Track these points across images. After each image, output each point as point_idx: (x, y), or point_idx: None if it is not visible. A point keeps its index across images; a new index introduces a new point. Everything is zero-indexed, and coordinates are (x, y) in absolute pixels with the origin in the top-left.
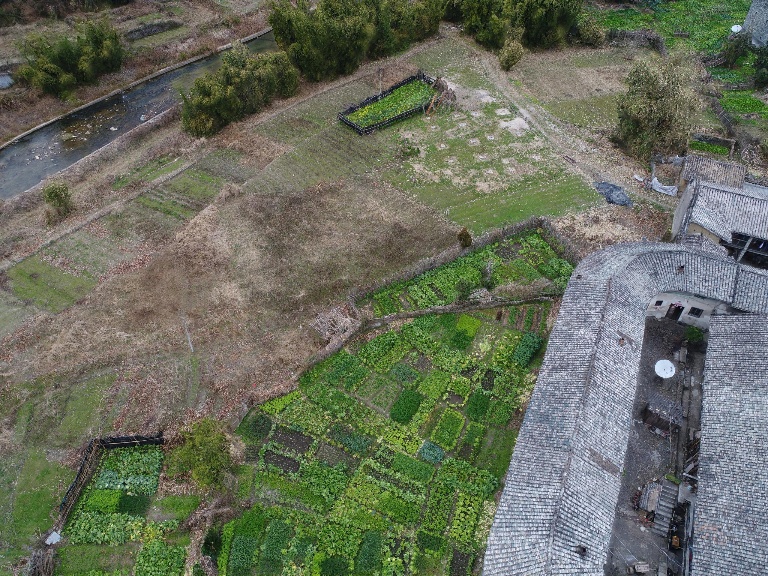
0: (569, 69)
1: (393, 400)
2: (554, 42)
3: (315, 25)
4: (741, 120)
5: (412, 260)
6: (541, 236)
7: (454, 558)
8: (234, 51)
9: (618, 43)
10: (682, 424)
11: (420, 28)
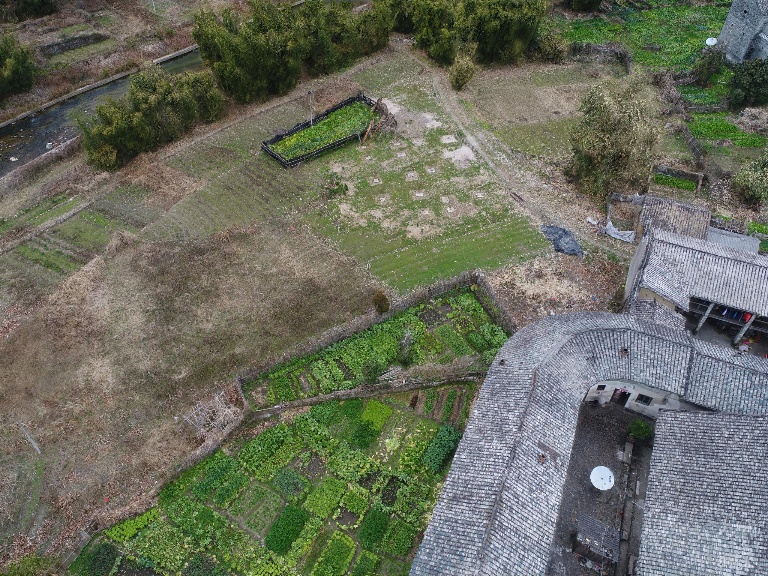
0: (527, 88)
1: (272, 520)
2: (513, 57)
3: (239, 42)
4: (712, 148)
5: (321, 327)
6: (475, 294)
7: None
8: (143, 73)
9: (582, 58)
10: (617, 559)
11: (366, 42)
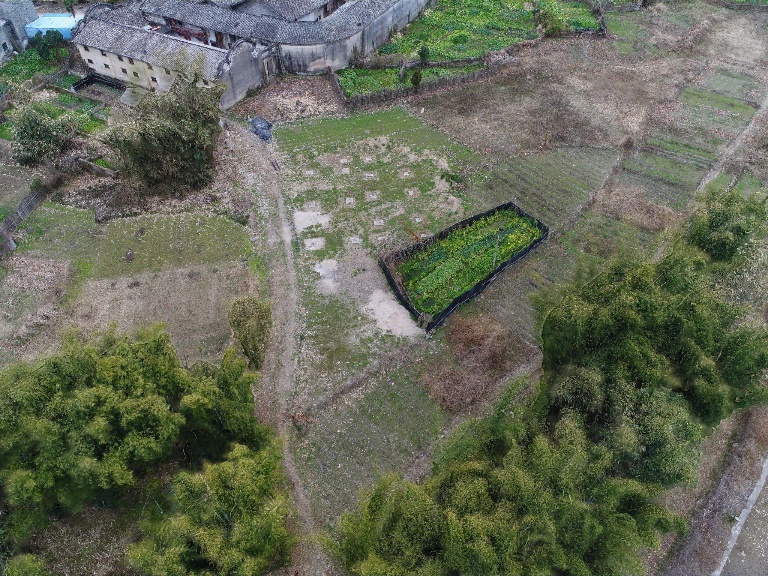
0: None
1: None
2: None
3: None
4: (0, 214)
5: None
6: None
7: None
8: (742, 222)
9: None
10: None
11: None
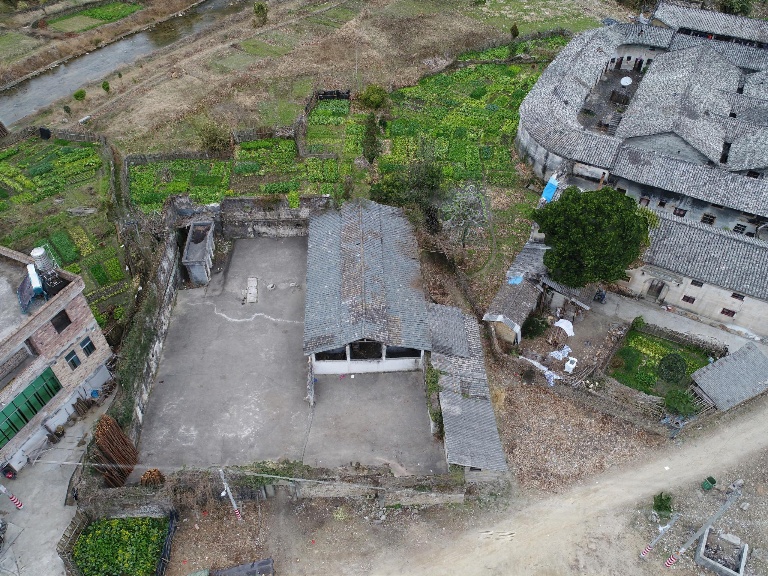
0: None
1: (471, 92)
2: None
3: None
4: None
5: None
6: None
7: (503, 136)
8: None
9: None
10: None
11: None
